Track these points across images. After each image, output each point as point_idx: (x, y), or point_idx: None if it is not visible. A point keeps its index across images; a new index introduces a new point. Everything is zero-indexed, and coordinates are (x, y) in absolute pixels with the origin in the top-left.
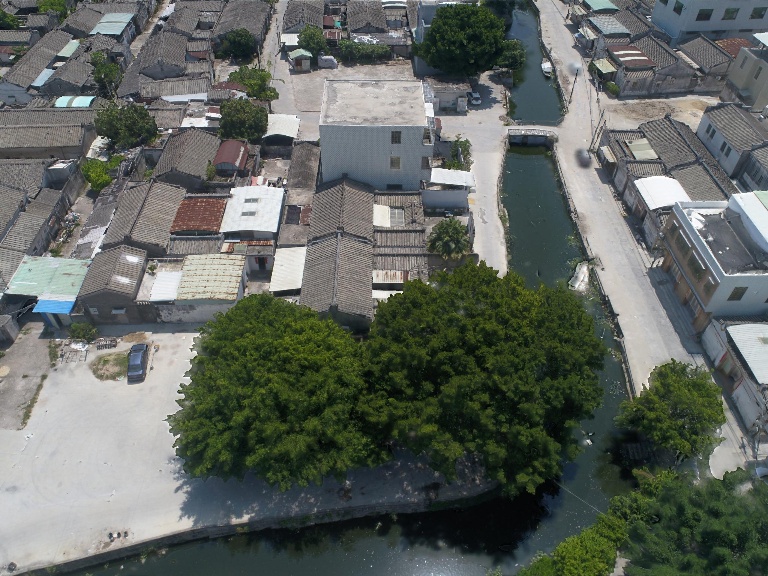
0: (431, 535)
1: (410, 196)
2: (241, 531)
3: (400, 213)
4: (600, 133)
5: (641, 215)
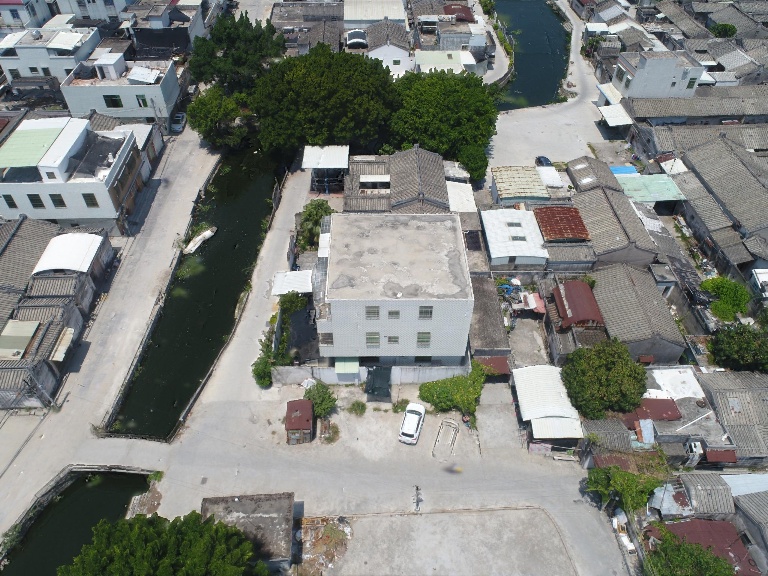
0: None
1: None
2: None
3: None
4: None
5: None
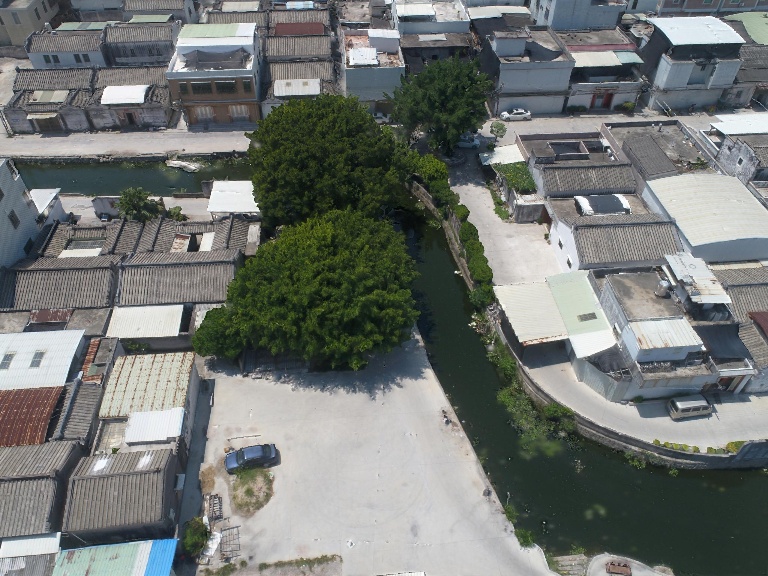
0: (411, 250)
1: (57, 231)
2: (425, 345)
3: (77, 244)
4: (3, 115)
5: (128, 121)
